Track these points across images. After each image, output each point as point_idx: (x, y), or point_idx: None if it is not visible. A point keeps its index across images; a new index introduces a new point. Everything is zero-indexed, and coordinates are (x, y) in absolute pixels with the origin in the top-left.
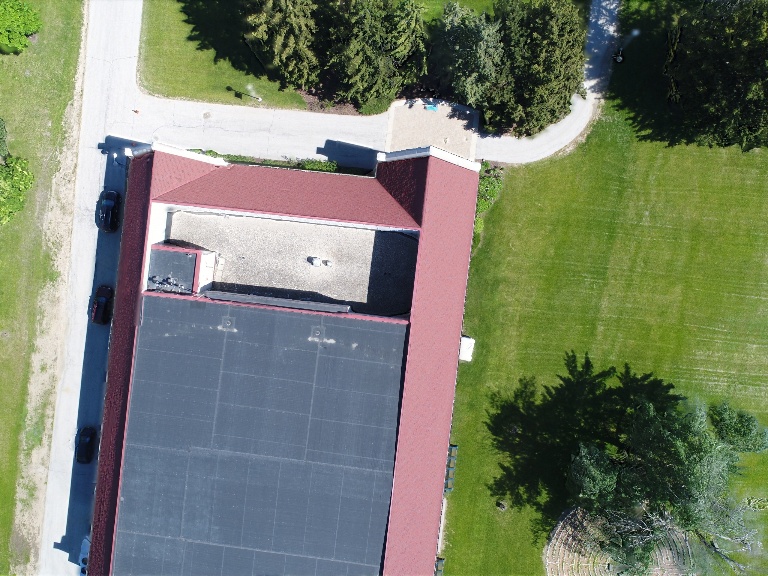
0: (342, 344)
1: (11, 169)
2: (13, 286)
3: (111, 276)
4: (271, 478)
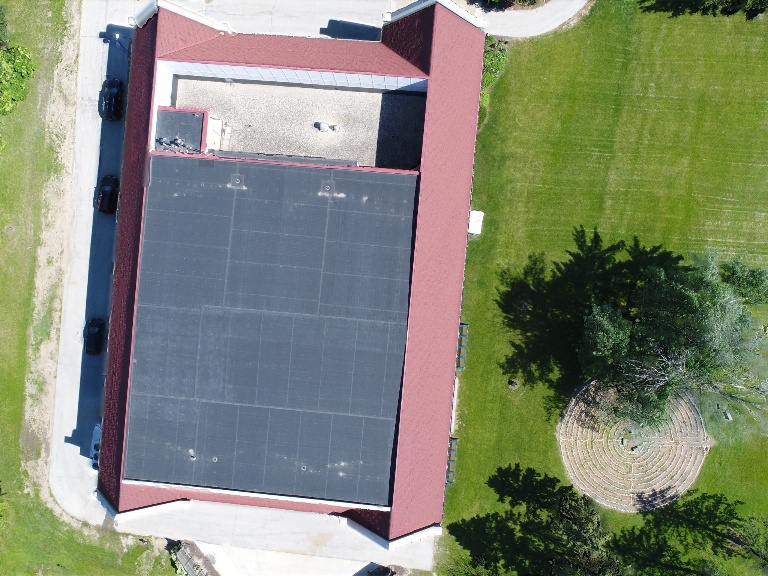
0: (352, 198)
1: (13, 55)
2: (17, 180)
3: (116, 166)
4: (284, 334)
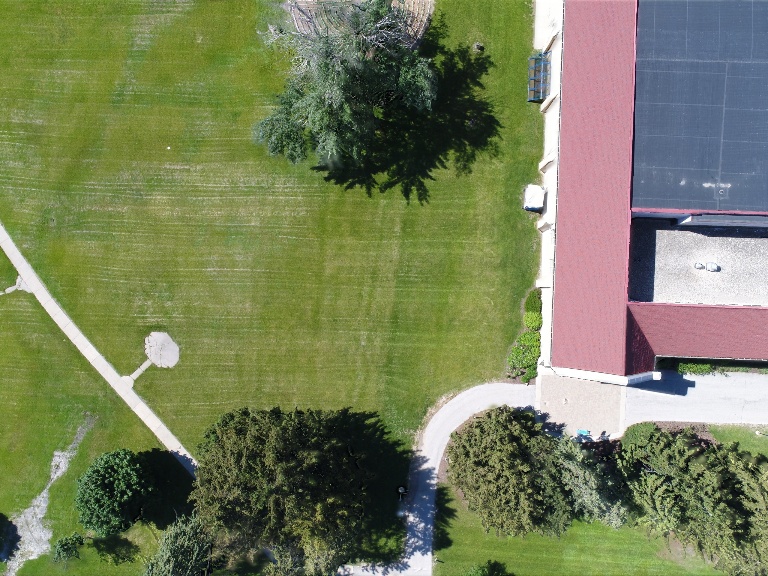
0: (696, 183)
1: None
2: None
3: None
4: (761, 41)
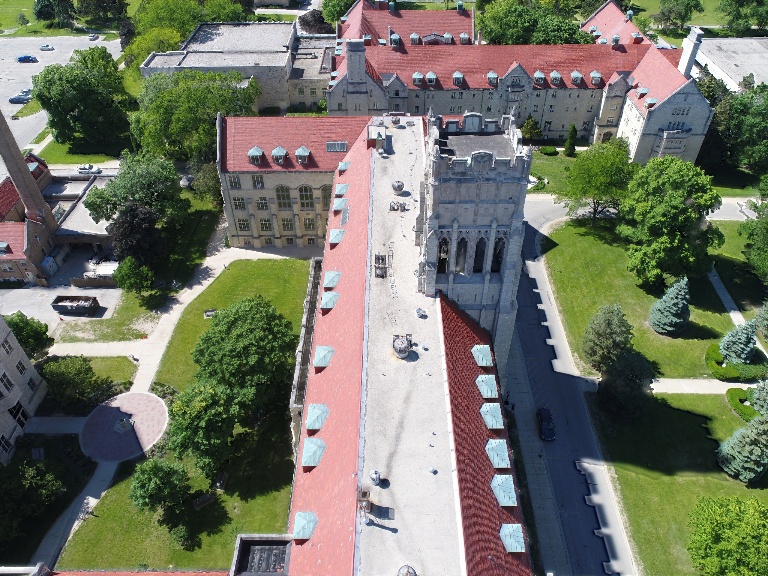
0: None
1: None
2: None
3: None
4: None
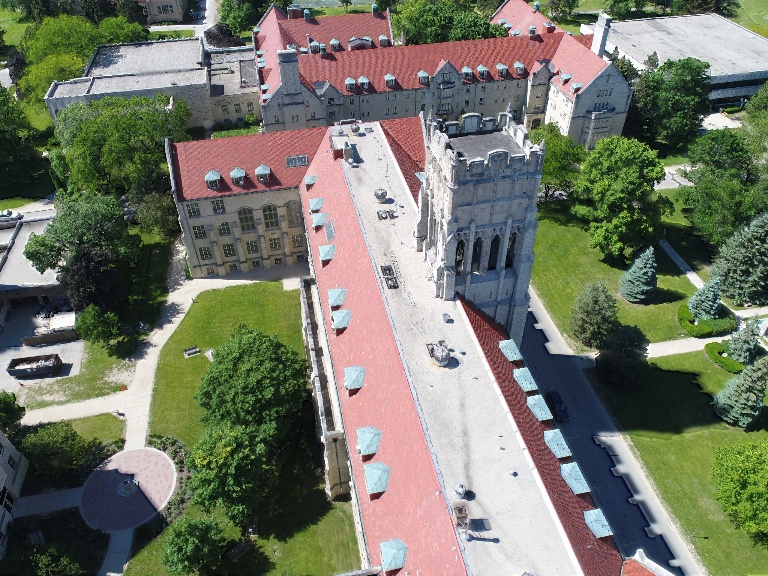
0: None
1: None
2: None
3: None
4: None
